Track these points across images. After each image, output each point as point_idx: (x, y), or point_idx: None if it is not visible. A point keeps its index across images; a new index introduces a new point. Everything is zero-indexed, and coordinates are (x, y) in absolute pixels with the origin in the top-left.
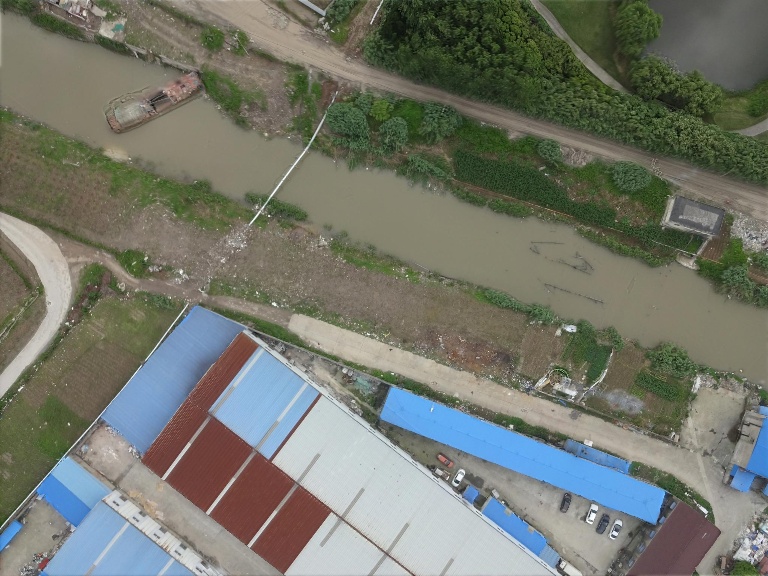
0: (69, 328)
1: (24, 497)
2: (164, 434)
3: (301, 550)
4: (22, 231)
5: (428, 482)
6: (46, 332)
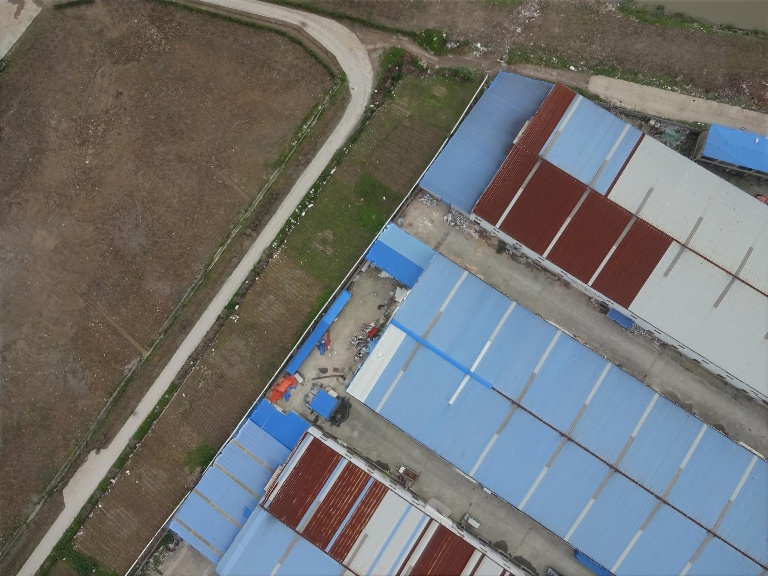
0: (374, 110)
1: (347, 271)
2: (495, 183)
3: (644, 283)
4: (320, 25)
5: (765, 208)
6: (352, 116)
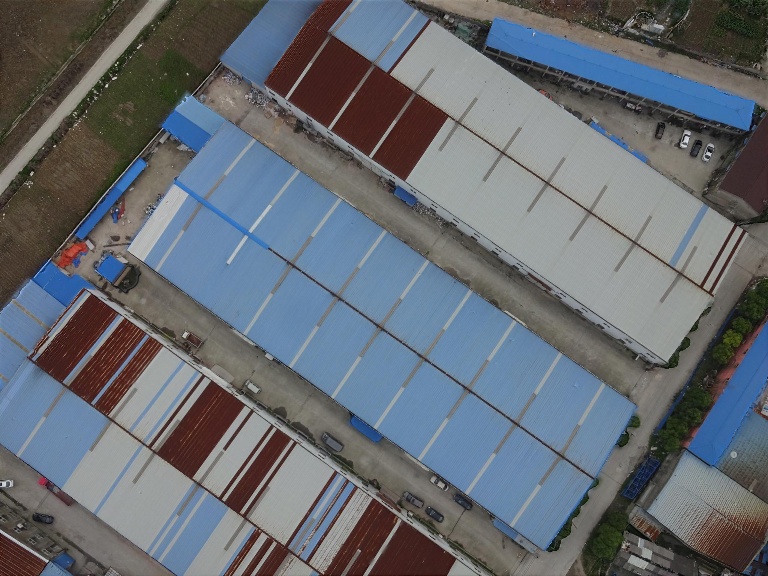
0: None
1: (146, 143)
2: (286, 56)
3: (421, 156)
4: None
5: (536, 94)
6: None
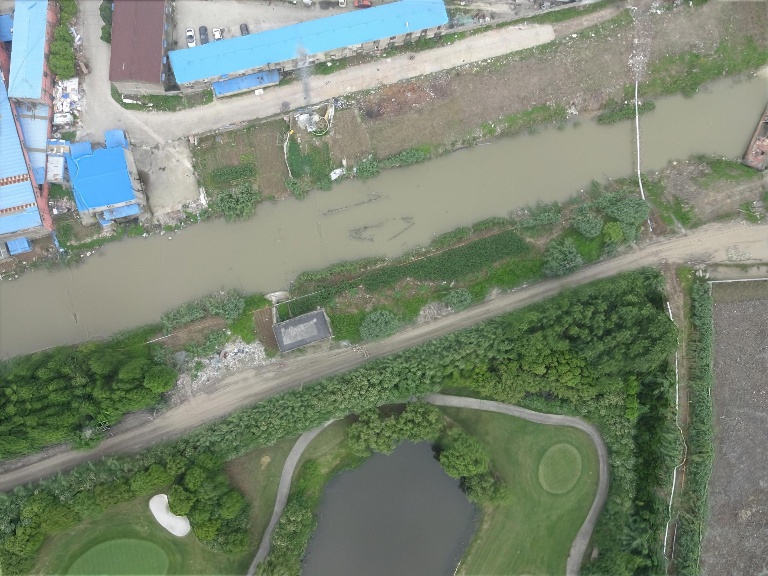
0: None
1: None
2: None
3: None
4: None
5: None
6: None
